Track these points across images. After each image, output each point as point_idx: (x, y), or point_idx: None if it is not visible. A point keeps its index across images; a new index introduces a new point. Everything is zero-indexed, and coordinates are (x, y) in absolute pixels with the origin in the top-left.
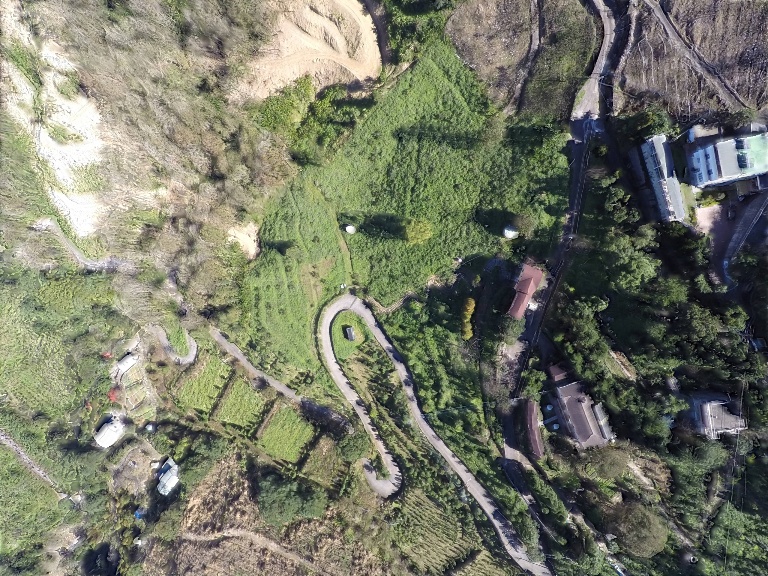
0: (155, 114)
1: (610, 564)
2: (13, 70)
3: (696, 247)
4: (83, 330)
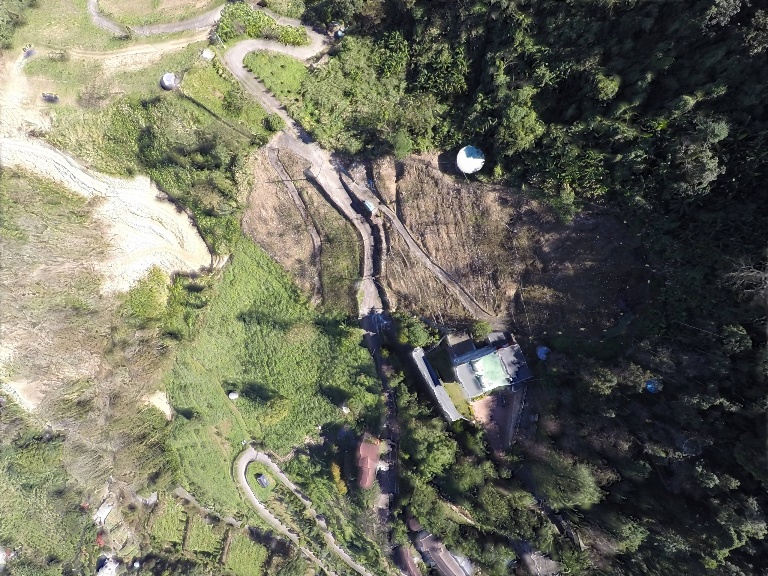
0: None
1: None
2: None
3: (476, 442)
4: (64, 482)
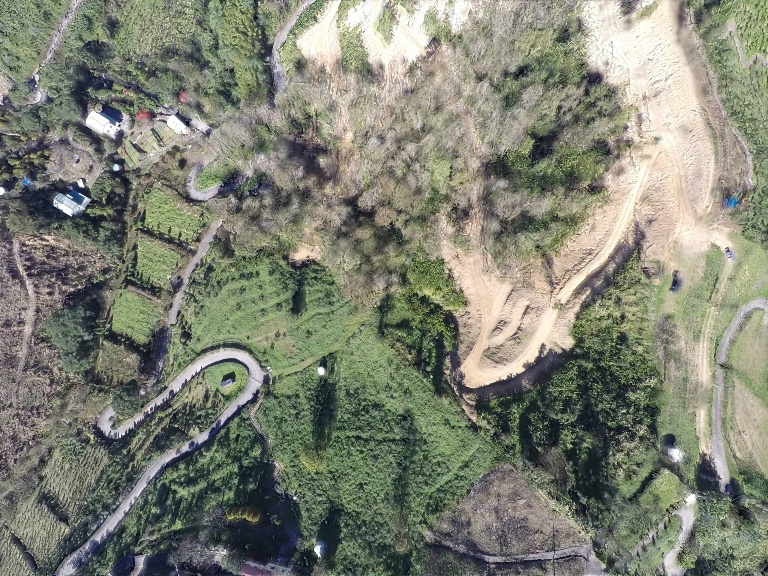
0: (403, 149)
1: None
2: None
3: None
4: None
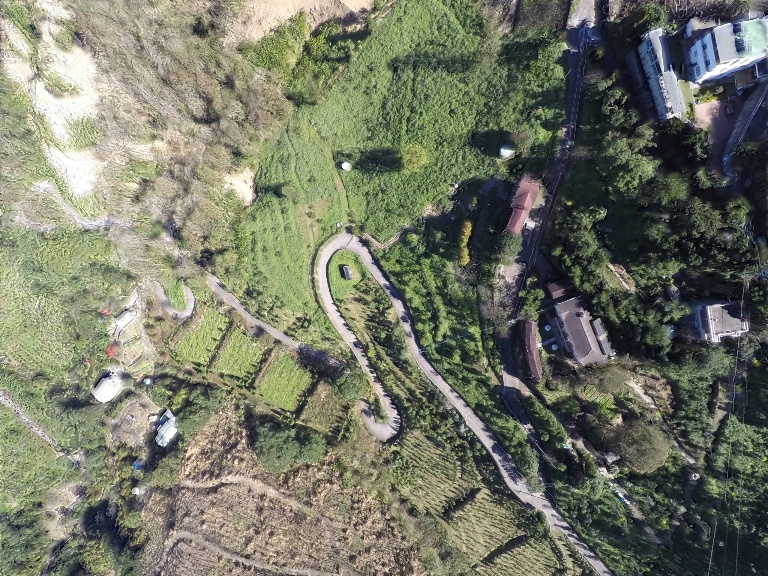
0: (150, 54)
1: (611, 489)
2: (9, 27)
3: (694, 142)
4: (81, 290)
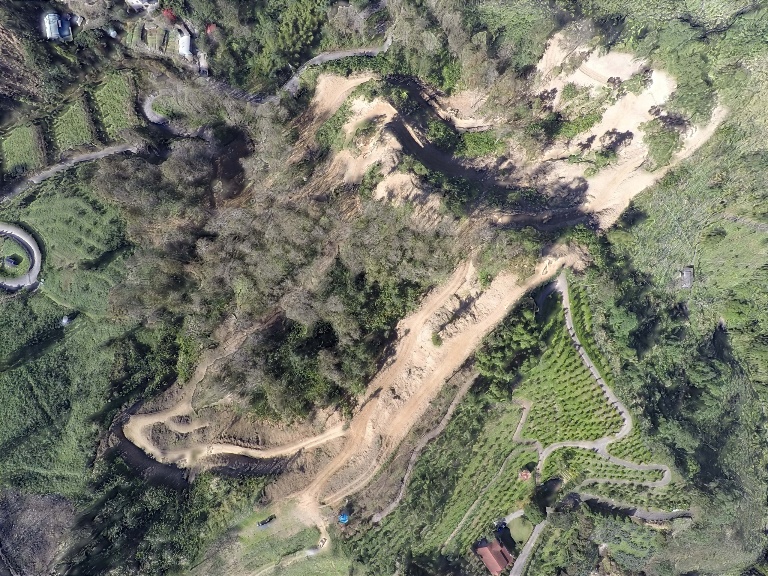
0: None
1: None
2: (500, 117)
3: None
4: None
